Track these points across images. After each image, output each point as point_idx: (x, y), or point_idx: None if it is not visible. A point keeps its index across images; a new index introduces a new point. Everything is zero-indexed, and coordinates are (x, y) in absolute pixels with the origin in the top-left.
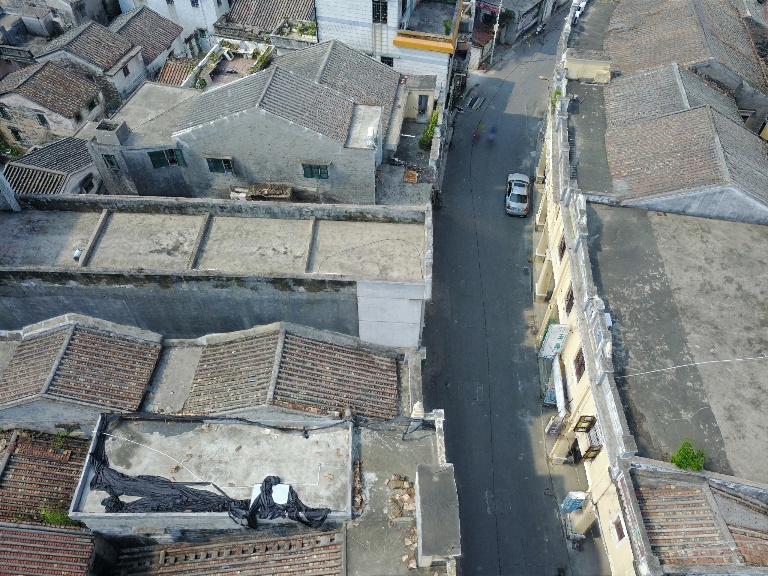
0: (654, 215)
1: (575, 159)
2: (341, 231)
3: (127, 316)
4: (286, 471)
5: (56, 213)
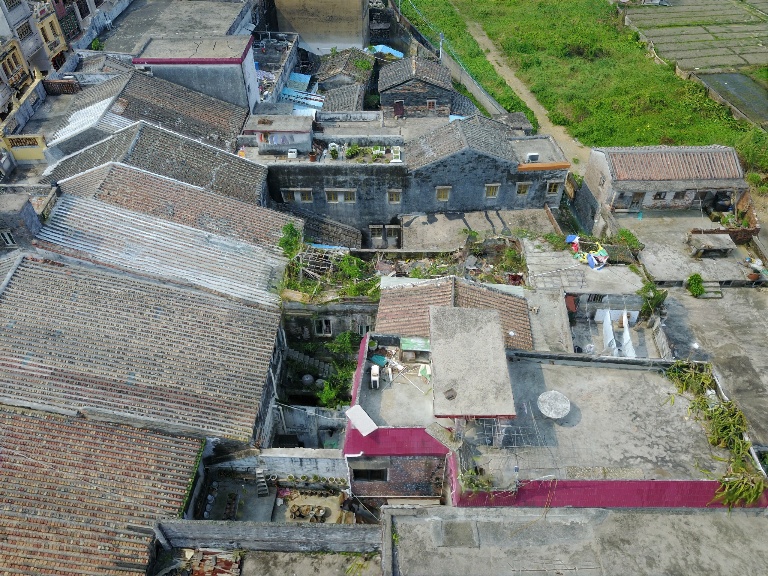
0: (175, 1)
1: None
2: None
3: None
4: None
5: None
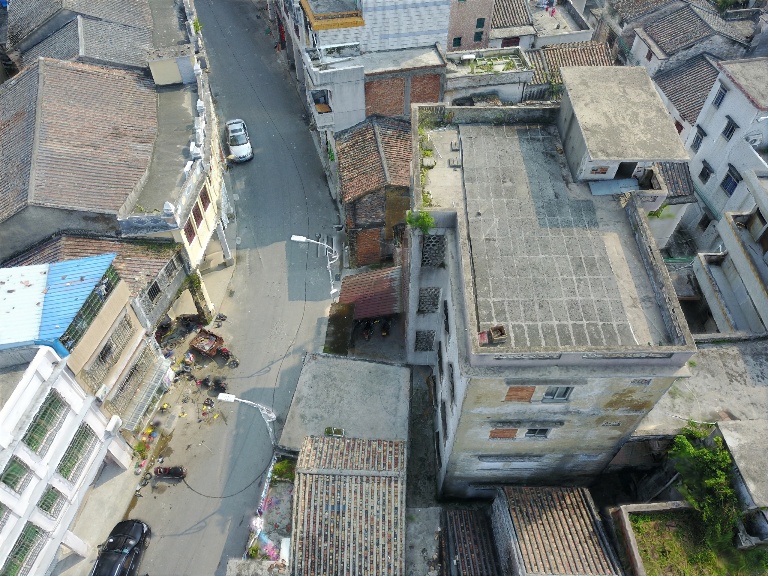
0: None
1: (177, 8)
2: None
3: None
4: None
5: None
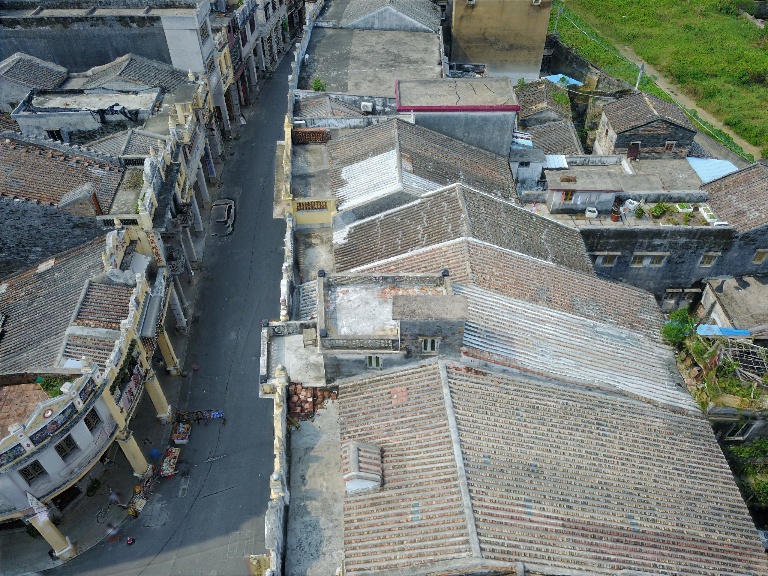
0: (357, 31)
1: (325, 15)
2: (162, 11)
3: (48, 53)
4: (123, 104)
5: (13, 11)
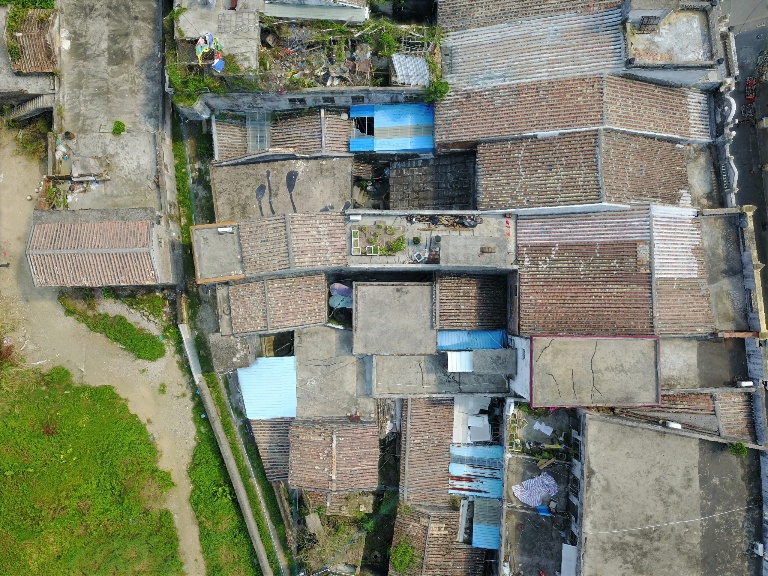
0: None
1: None
2: None
3: None
4: None
5: None
